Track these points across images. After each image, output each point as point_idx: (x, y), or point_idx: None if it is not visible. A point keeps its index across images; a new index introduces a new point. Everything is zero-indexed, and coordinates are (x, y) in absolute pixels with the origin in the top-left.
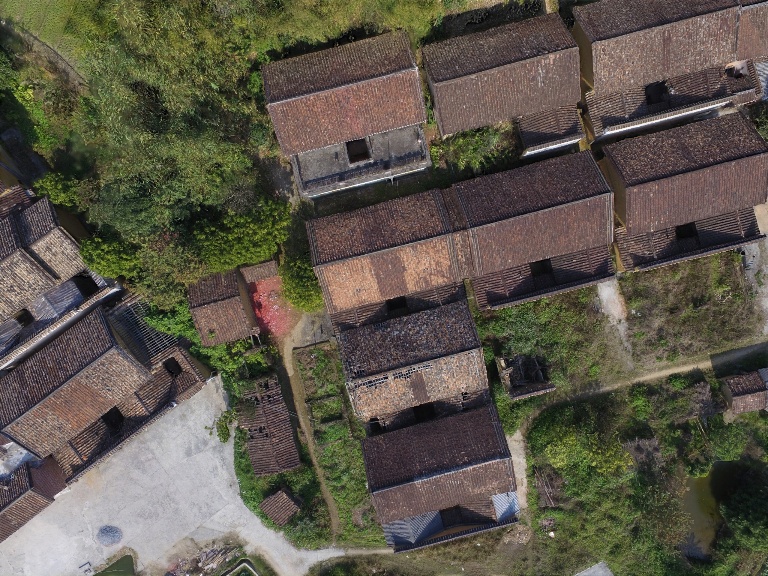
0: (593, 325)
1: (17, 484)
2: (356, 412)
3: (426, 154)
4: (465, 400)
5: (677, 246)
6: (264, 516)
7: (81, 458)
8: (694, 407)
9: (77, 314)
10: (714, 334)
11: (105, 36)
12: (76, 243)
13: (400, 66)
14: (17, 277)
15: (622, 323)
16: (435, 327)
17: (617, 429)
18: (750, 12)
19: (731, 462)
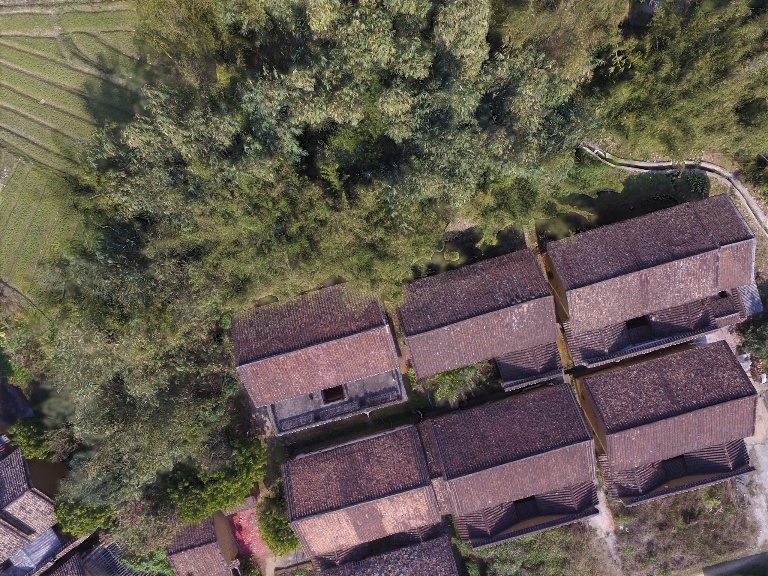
0: (580, 544)
1: None
2: None
3: (402, 389)
4: None
5: (663, 472)
6: None
7: None
8: None
9: (54, 564)
10: (706, 547)
11: (67, 329)
12: (50, 500)
13: (370, 322)
14: None
15: (610, 536)
16: (415, 569)
17: None
18: (730, 249)
19: None
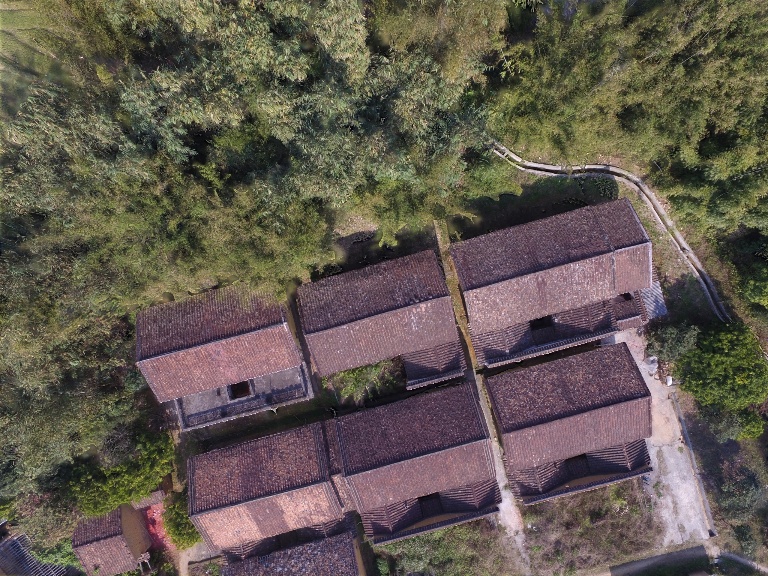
0: (487, 542)
1: None
2: None
3: (308, 386)
4: None
5: (566, 472)
6: None
7: None
8: None
9: None
10: (612, 547)
11: None
12: None
13: (269, 320)
14: None
15: (519, 534)
16: (317, 564)
17: None
18: (626, 253)
19: None
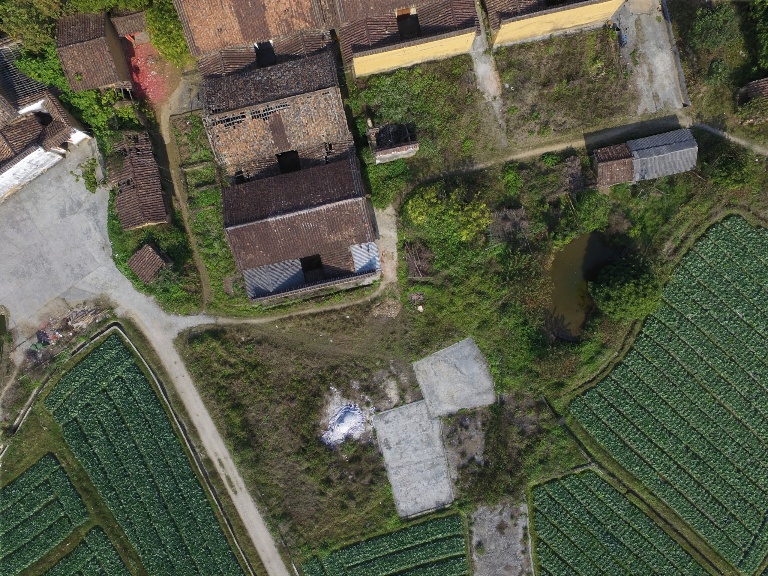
0: (465, 96)
1: None
2: (217, 157)
3: None
4: (329, 155)
5: None
6: (135, 278)
7: None
8: (564, 182)
9: None
10: (587, 112)
11: None
12: None
13: None
14: None
15: (497, 100)
16: (297, 73)
17: (487, 202)
18: None
19: (603, 244)
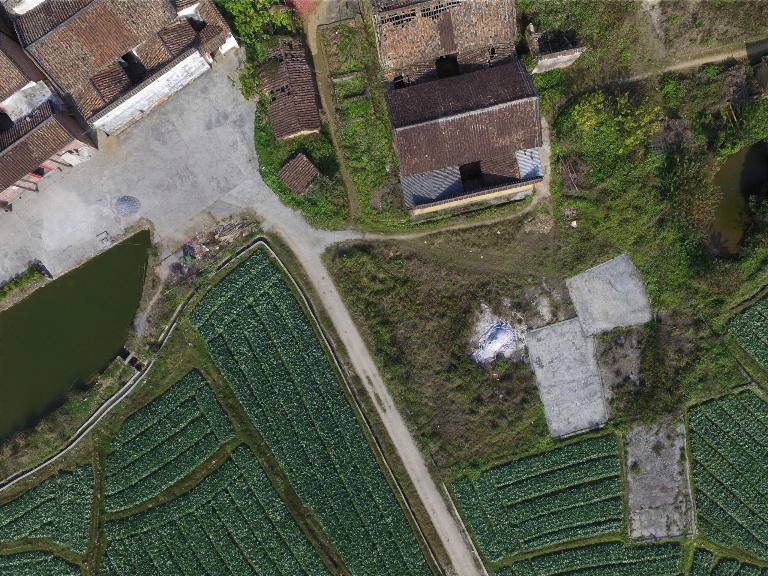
0: (626, 3)
1: (39, 115)
2: (381, 59)
3: None
4: (492, 59)
5: None
6: (282, 191)
7: (103, 98)
8: (727, 92)
9: None
10: (751, 20)
11: None
12: None
13: None
14: None
15: (655, 9)
16: None
17: None
18: None
19: (763, 159)
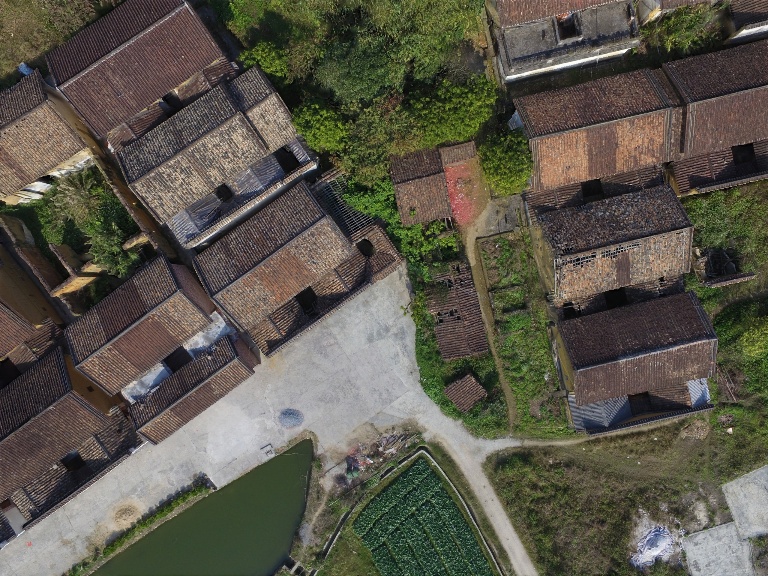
0: None
1: (220, 354)
2: (556, 293)
3: None
4: (661, 287)
5: None
6: (444, 403)
7: (280, 332)
8: None
9: (282, 187)
10: None
11: None
12: (288, 112)
13: None
14: (233, 143)
15: None
16: (641, 208)
17: None
18: None
19: None
